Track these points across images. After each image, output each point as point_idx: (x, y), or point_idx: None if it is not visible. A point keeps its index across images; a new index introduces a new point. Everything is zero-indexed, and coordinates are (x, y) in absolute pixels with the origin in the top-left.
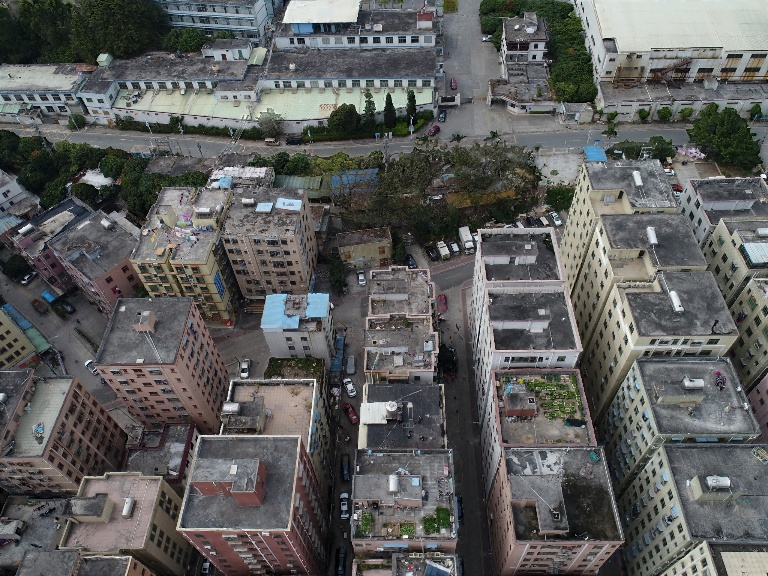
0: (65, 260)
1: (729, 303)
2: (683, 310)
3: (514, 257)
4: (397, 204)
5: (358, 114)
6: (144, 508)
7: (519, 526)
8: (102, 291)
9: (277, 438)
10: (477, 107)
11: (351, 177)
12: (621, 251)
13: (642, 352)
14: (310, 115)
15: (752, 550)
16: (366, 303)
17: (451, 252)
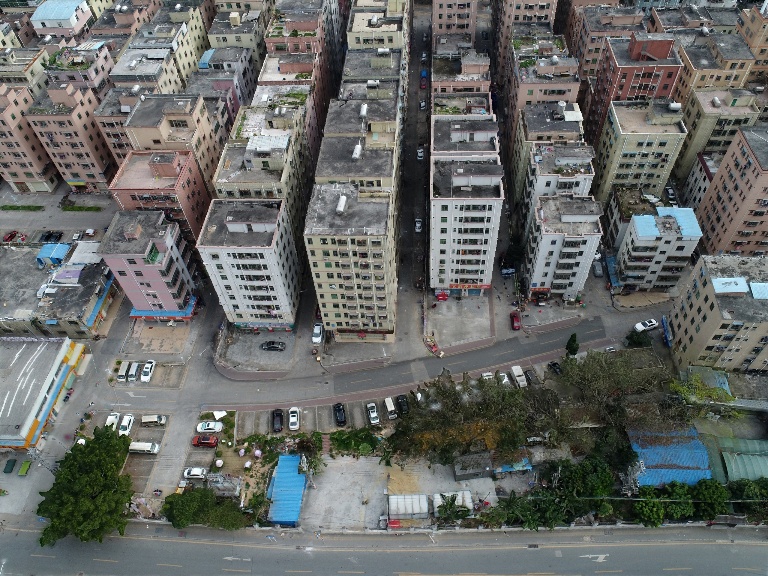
0: None
1: None
2: None
3: None
4: None
5: None
6: (706, 105)
7: None
8: None
9: (632, 68)
10: None
11: (677, 457)
12: None
13: None
14: None
15: None
16: (599, 331)
17: (509, 375)
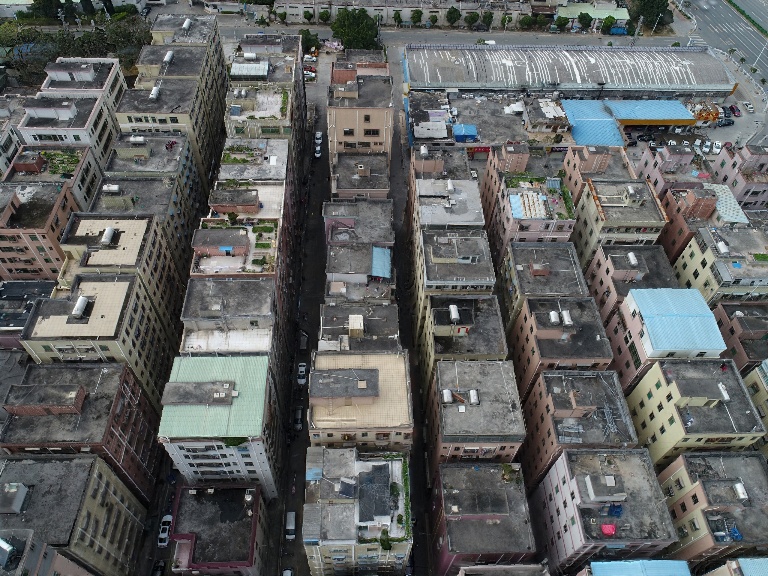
0: None
1: None
2: (154, 97)
3: (71, 73)
4: None
5: (63, 3)
6: None
7: None
8: None
9: None
10: (180, 7)
11: None
12: (146, 68)
13: (130, 130)
14: (20, 1)
15: (104, 219)
16: None
17: None
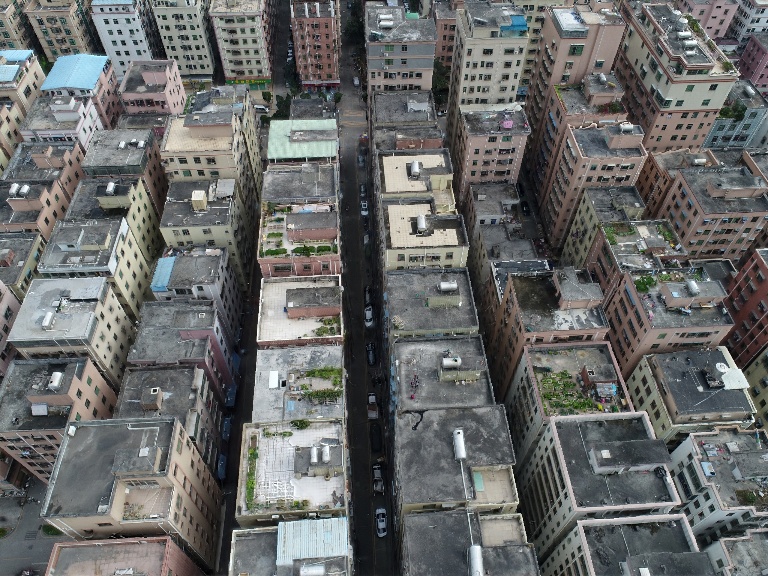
0: None
1: (349, 537)
2: None
3: None
4: None
5: None
6: None
7: (584, 282)
8: None
9: None
10: None
11: None
12: None
13: None
14: None
15: None
16: None
17: None
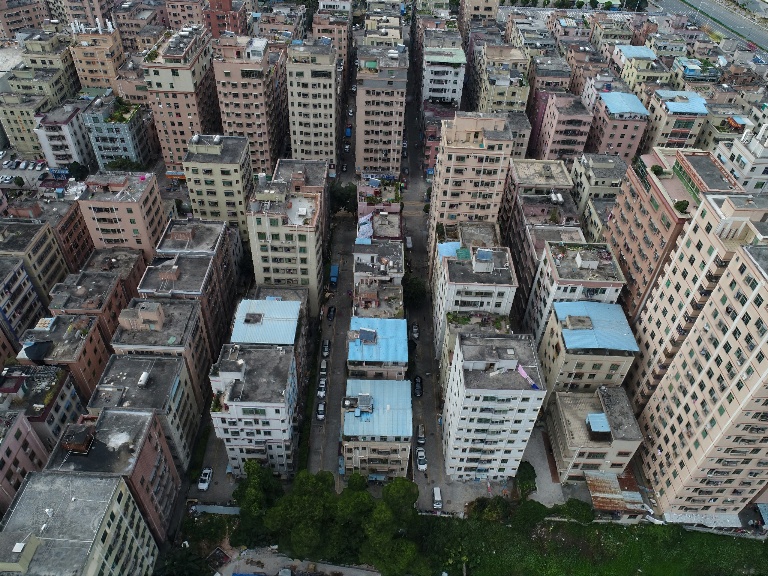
0: (141, 4)
1: None
2: None
3: None
4: (298, 3)
5: None
6: None
7: None
8: (158, 16)
9: (237, 3)
10: None
11: (279, 1)
12: None
13: None
14: None
15: None
16: None
17: None
